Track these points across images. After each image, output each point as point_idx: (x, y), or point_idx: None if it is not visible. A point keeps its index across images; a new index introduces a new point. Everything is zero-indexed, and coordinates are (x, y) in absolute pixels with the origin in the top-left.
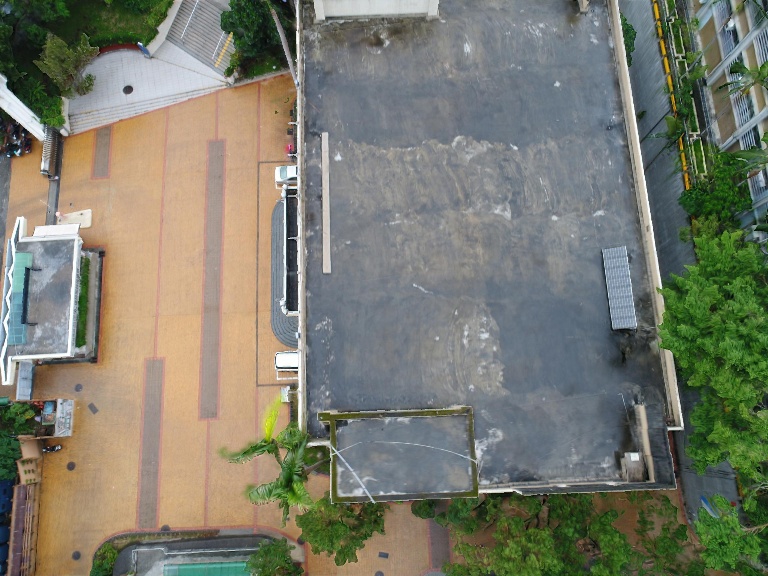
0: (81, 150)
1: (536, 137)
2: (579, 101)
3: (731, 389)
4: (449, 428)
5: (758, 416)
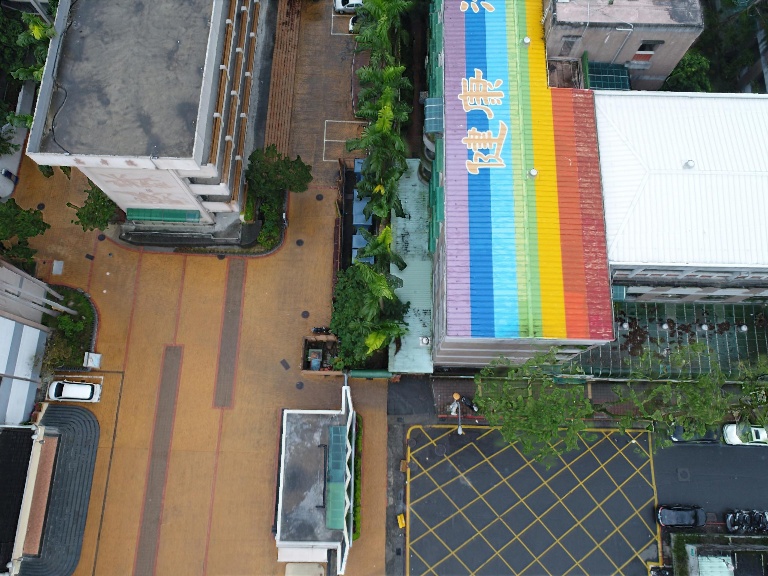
0: None
1: None
2: None
3: None
4: None
5: None
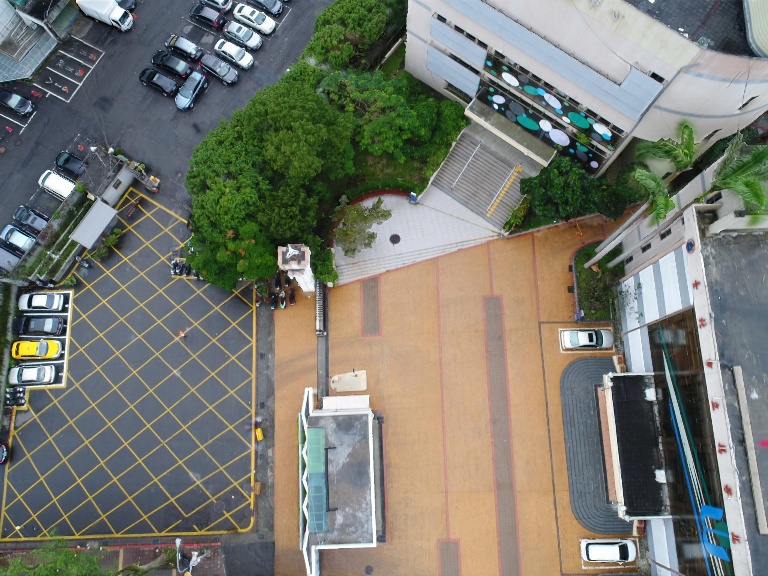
0: (348, 303)
1: None
2: None
3: None
4: None
5: None
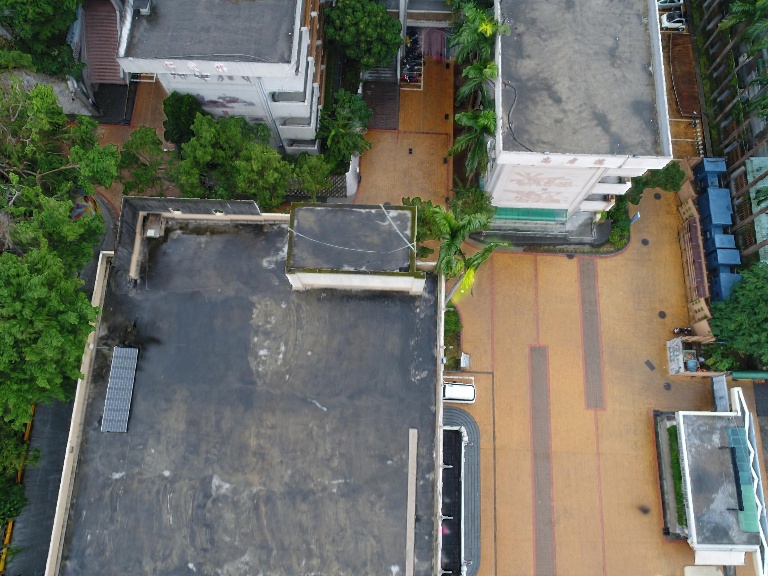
0: None
1: None
2: None
3: (49, 260)
4: (309, 259)
5: None
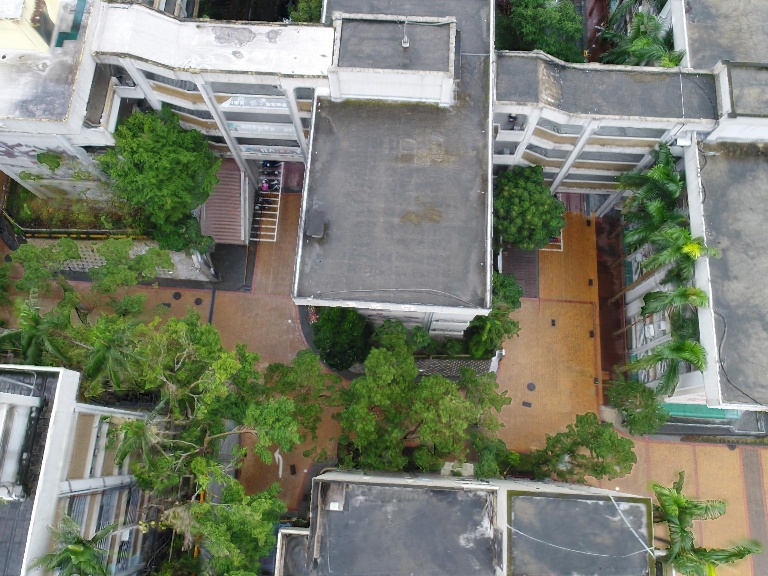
0: None
1: None
2: None
3: None
4: (531, 563)
5: None
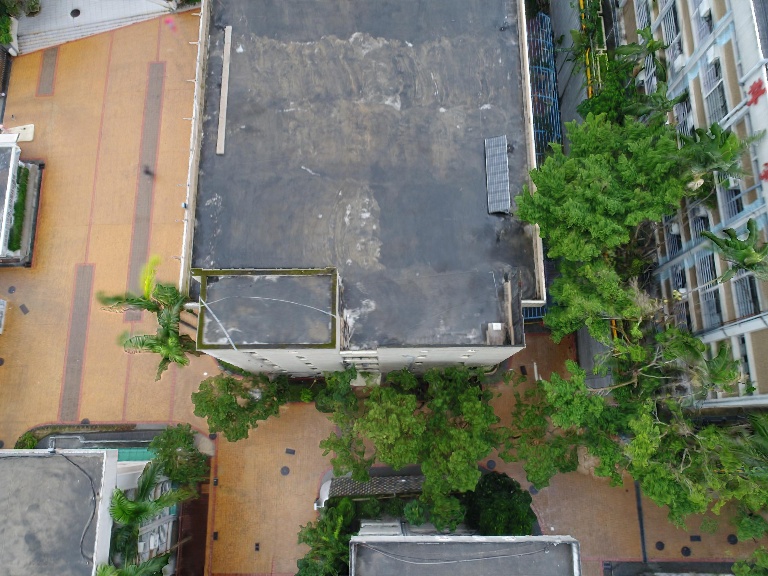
0: (28, 69)
1: (431, 35)
2: (475, 3)
3: (575, 250)
4: (314, 287)
5: (598, 274)
